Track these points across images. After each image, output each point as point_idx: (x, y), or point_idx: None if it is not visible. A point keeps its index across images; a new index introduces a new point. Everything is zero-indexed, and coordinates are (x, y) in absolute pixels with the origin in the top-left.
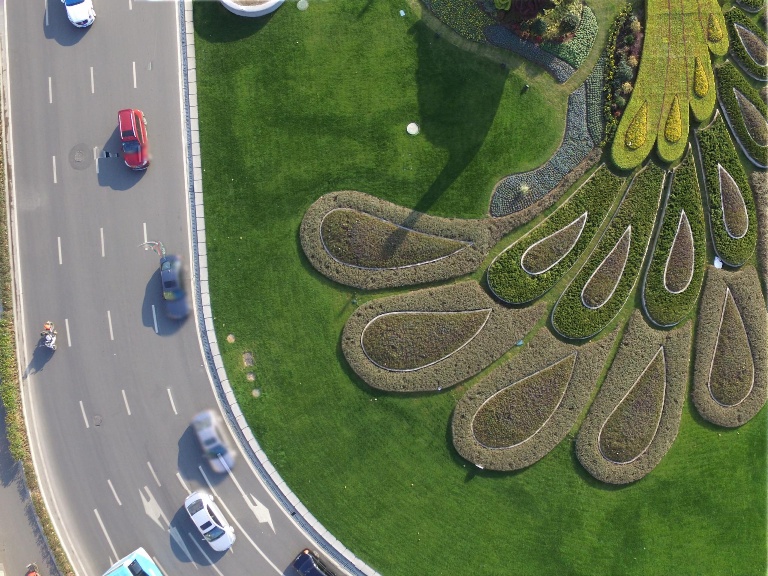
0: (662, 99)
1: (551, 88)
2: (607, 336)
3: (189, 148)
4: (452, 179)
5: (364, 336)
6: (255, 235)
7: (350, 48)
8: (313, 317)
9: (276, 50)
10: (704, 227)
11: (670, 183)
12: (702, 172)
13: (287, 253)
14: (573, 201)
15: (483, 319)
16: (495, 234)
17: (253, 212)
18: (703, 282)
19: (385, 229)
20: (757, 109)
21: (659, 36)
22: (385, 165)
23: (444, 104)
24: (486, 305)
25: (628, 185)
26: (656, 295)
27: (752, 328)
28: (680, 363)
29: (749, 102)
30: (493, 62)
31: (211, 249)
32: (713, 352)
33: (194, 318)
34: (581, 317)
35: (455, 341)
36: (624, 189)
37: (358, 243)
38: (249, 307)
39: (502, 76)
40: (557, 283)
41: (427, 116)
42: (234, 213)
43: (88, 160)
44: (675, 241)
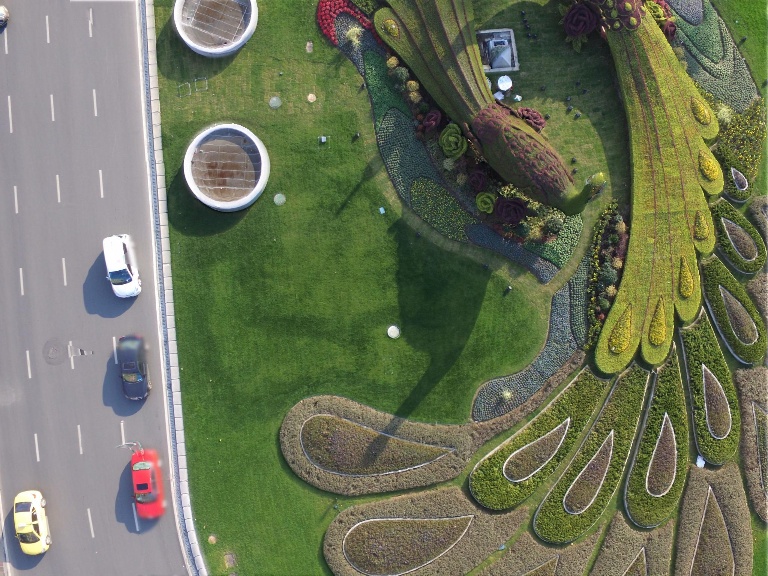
0: (647, 301)
1: (534, 288)
2: (589, 539)
3: (166, 345)
4: (433, 384)
5: (346, 543)
6: (234, 437)
7: (329, 247)
8: (294, 522)
9: (253, 247)
10: (687, 429)
11: (654, 384)
12: (686, 372)
13: (267, 457)
14: (556, 407)
15: (465, 526)
16: (477, 441)
17: (232, 414)
18: (685, 482)
19: (366, 437)
20: (743, 306)
21: (644, 237)
22: (365, 369)
23: (425, 307)
24: (468, 512)
25: (611, 386)
26: (638, 499)
27: (733, 526)
28: (661, 564)
29: (735, 299)
30: (475, 262)
31: (190, 450)
32: (694, 550)
33: (174, 519)
34: (563, 523)
35: (437, 548)
36: (607, 391)
37: (339, 452)
38: (230, 510)
39: (484, 277)
40: (539, 487)
41: (408, 319)
42: (213, 414)
43: (62, 358)
44: (658, 444)
